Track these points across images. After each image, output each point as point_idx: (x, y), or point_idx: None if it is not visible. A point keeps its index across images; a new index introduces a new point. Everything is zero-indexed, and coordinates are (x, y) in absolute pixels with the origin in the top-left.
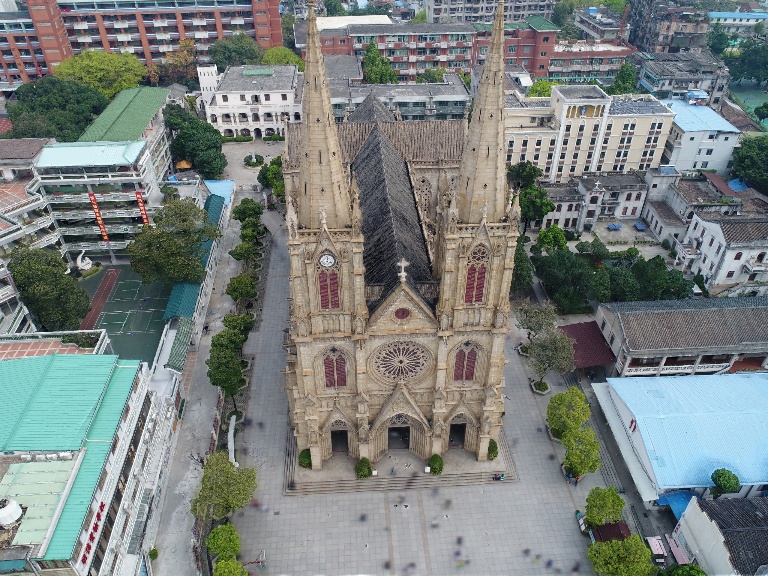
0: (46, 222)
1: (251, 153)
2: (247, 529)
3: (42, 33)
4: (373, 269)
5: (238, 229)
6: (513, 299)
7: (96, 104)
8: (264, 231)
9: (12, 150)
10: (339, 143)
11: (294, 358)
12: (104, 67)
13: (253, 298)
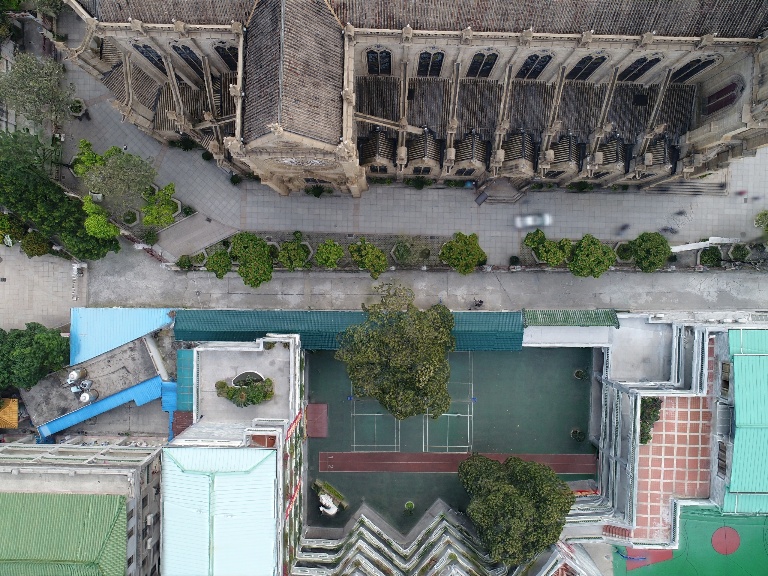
0: None
1: None
2: (759, 227)
3: None
4: (760, 3)
5: (217, 290)
6: None
7: None
8: (297, 233)
9: None
10: (314, 35)
11: (701, 156)
12: None
13: (410, 250)
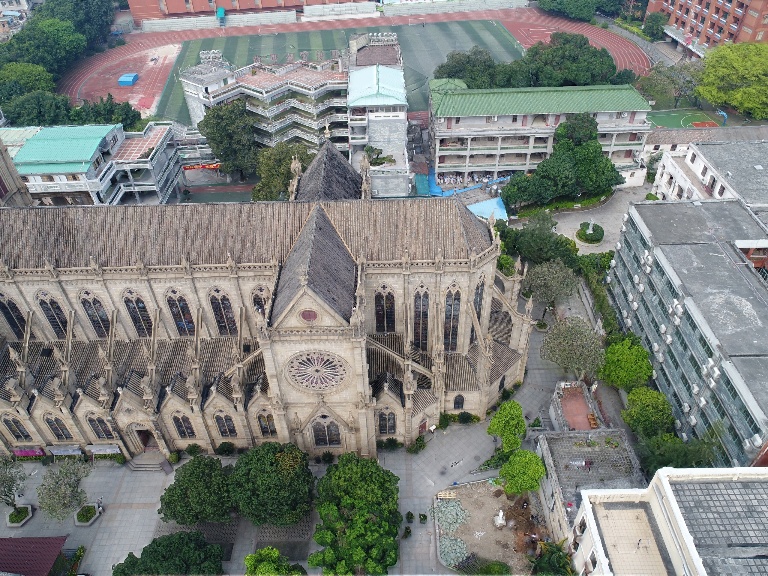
0: (312, 110)
1: (591, 221)
2: None
3: (753, 6)
4: None
5: None
6: (201, 522)
7: (570, 78)
8: None
9: (372, 56)
10: None
11: None
12: (737, 66)
13: None
